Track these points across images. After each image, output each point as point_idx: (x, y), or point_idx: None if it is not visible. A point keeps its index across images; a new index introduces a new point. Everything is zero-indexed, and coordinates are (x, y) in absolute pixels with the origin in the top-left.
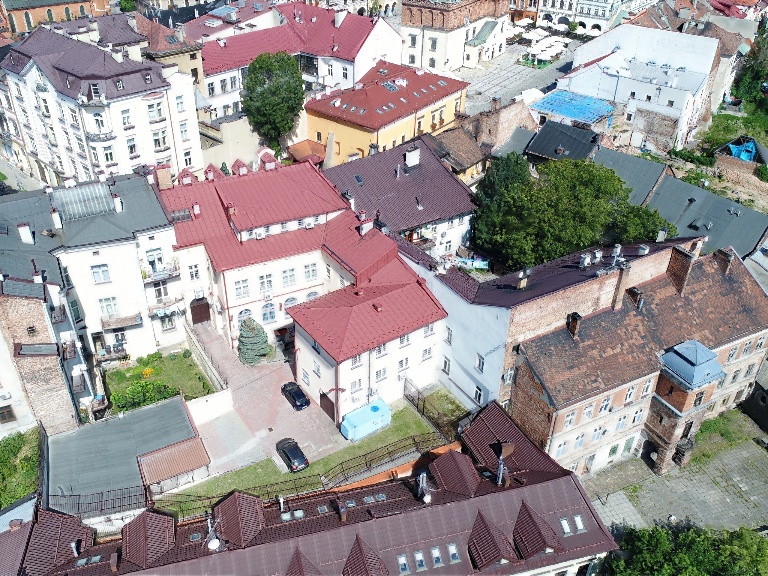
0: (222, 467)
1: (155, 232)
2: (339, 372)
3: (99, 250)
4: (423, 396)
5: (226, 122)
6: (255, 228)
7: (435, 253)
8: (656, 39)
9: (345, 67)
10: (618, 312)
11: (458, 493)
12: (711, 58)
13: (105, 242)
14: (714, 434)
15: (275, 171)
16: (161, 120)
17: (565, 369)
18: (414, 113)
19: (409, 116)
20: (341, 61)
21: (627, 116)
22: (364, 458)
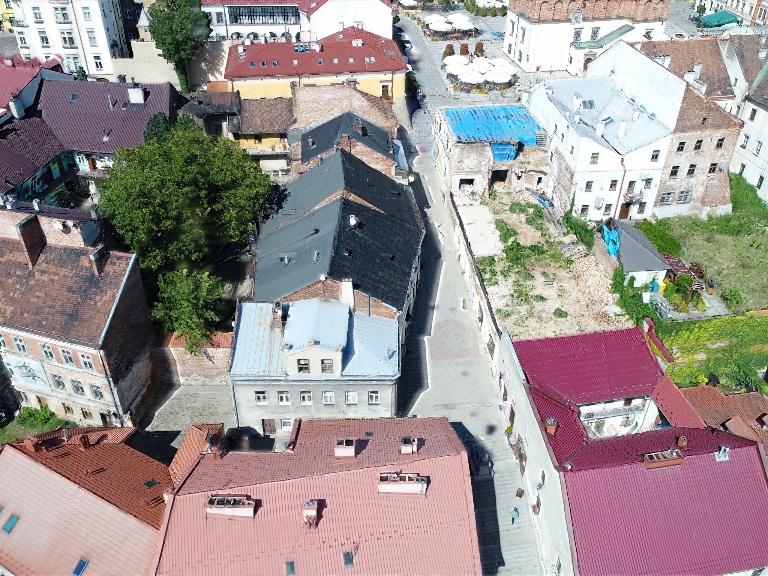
0: None
1: None
2: None
3: None
4: None
5: (136, 40)
6: None
7: None
8: (640, 68)
9: None
10: None
11: None
12: (677, 108)
13: None
14: None
15: (13, 68)
16: (65, 22)
17: None
18: (298, 78)
19: (289, 79)
20: None
21: (551, 155)
22: None
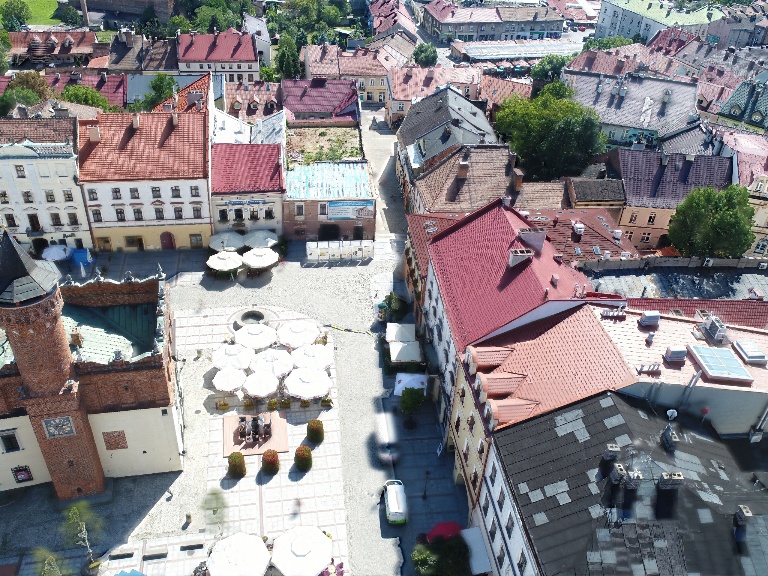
0: None
1: None
2: None
3: None
4: None
5: None
6: None
7: None
8: None
9: None
10: None
11: None
12: None
13: None
14: None
15: None
16: None
17: None
18: None
19: None
20: None
21: None
22: None
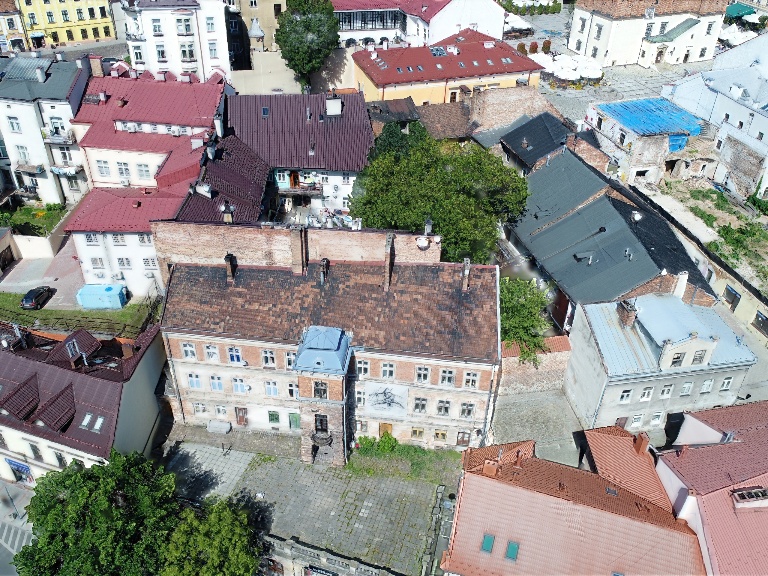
0: (1, 288)
1: (55, 103)
2: (75, 242)
3: (11, 105)
4: (146, 294)
5: None
6: (127, 121)
7: (330, 205)
8: None
9: (425, 28)
10: (297, 276)
11: (46, 357)
12: None
13: (13, 99)
14: (405, 460)
15: (190, 84)
16: (188, 34)
17: (198, 301)
18: (445, 81)
19: (436, 83)
20: (423, 22)
21: (718, 143)
22: (78, 322)
